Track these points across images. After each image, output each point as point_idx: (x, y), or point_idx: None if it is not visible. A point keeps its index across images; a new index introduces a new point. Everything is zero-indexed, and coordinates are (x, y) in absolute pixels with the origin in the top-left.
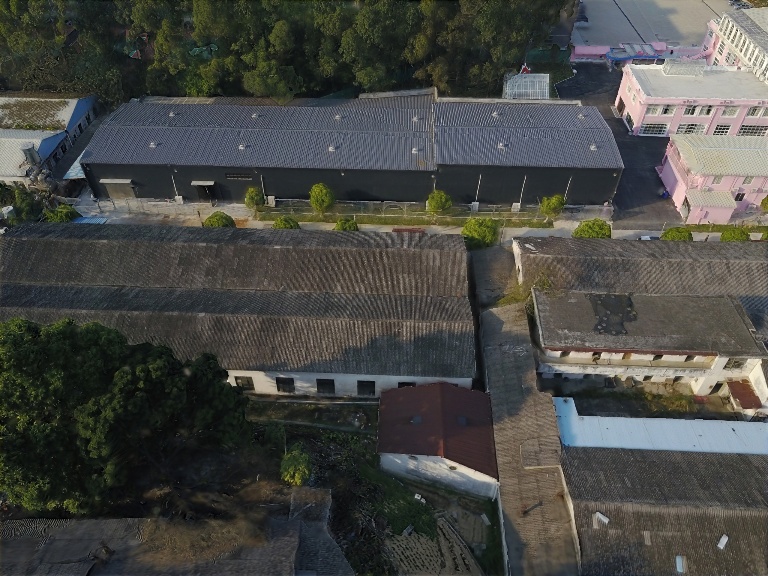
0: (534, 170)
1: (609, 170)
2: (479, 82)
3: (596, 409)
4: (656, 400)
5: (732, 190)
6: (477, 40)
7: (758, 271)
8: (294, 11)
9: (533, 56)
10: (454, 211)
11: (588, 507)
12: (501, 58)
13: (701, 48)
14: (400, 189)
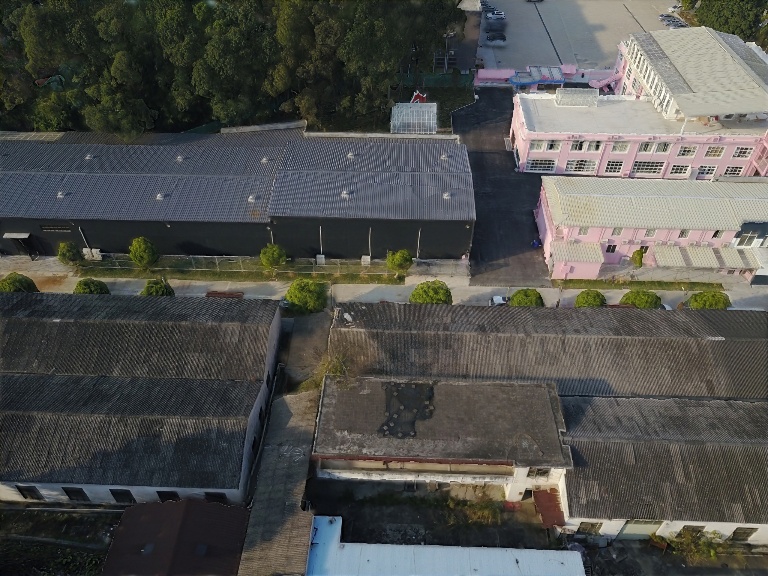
0: (377, 222)
1: (459, 222)
2: (353, 114)
3: (387, 520)
4: (459, 508)
5: (601, 242)
6: (347, 70)
7: (596, 348)
8: (138, 40)
9: (434, 80)
10: (299, 264)
11: None
12: (371, 90)
13: (613, 71)
14: (236, 241)
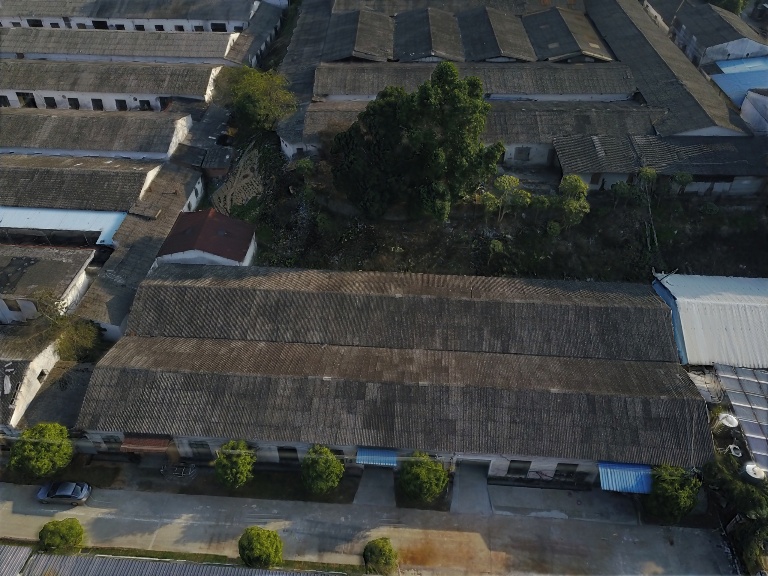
0: None
1: None
2: None
3: None
4: None
5: None
6: None
7: None
8: None
9: None
10: None
11: None
12: None
13: None
14: None
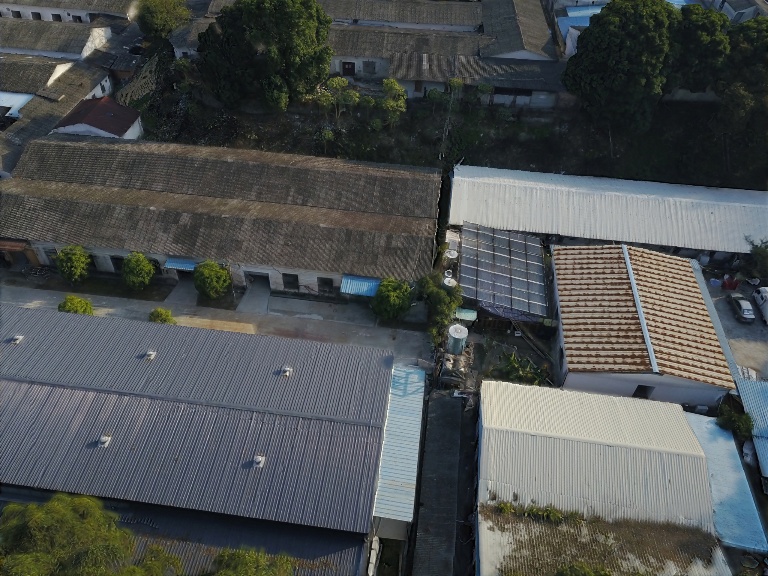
0: None
1: None
2: None
3: None
4: None
5: None
6: None
7: None
8: None
9: None
10: None
11: None
12: None
13: None
14: None
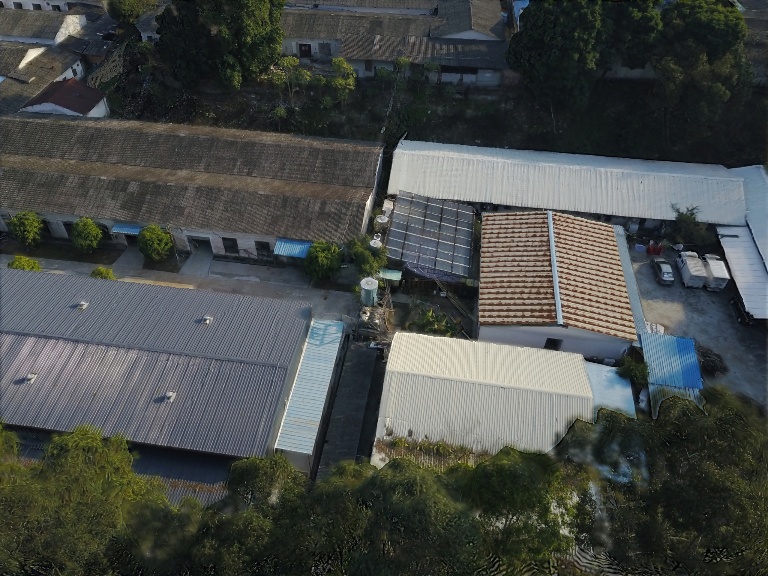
0: None
1: None
2: None
3: None
4: None
5: None
6: None
7: None
8: None
9: None
10: None
11: None
12: None
13: None
14: None
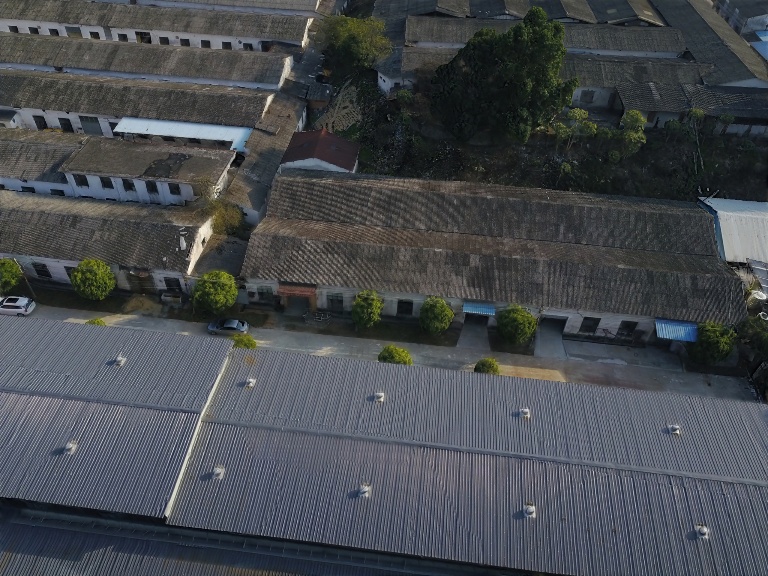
0: None
1: None
2: None
3: None
4: None
5: None
6: None
7: None
8: None
9: None
10: None
11: (261, 95)
12: None
13: None
14: None
